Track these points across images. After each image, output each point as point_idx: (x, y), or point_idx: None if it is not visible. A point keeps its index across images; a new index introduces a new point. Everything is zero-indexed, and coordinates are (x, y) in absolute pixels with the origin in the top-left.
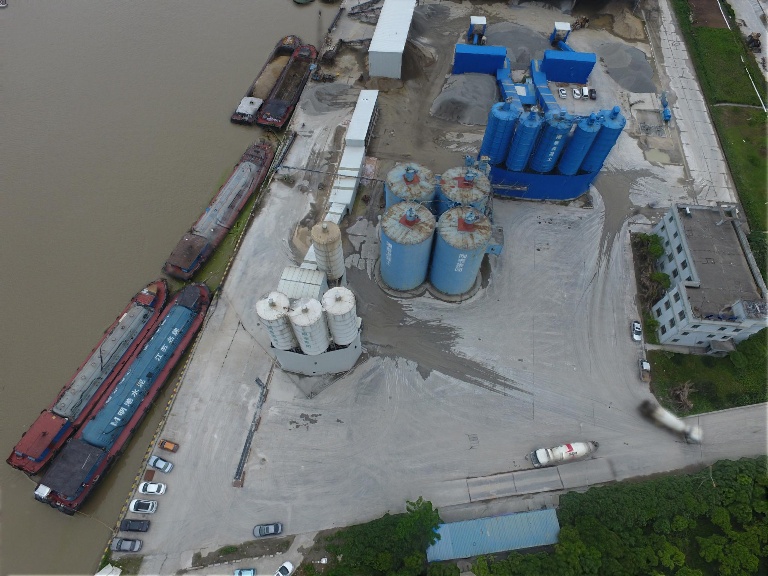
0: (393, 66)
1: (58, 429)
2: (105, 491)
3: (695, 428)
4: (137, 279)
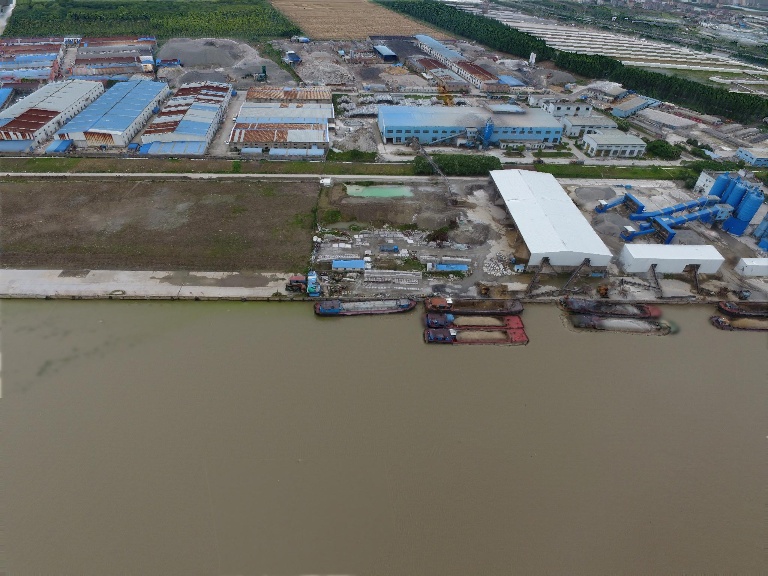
0: None
1: None
2: None
3: None
4: None
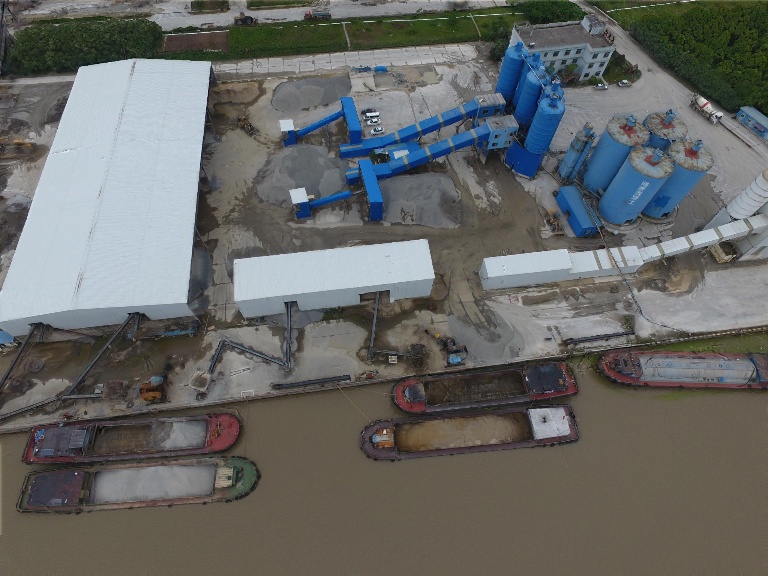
0: None
1: None
2: None
3: (641, 68)
4: None
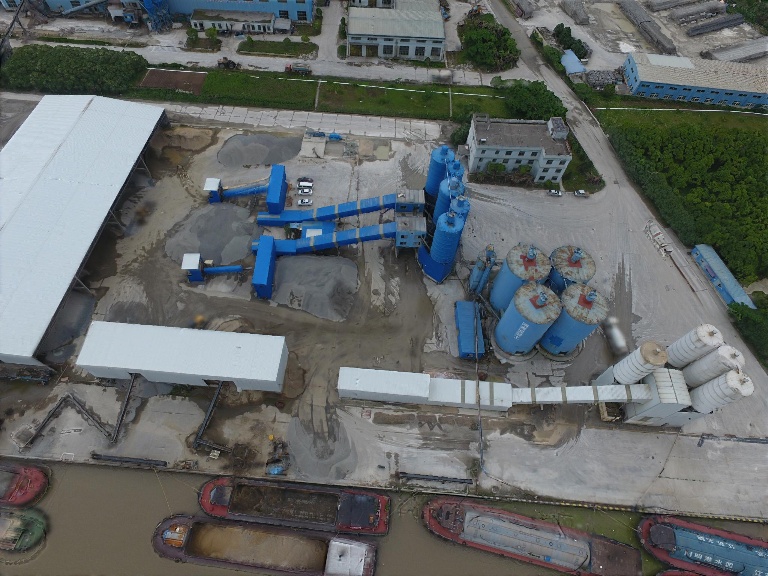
0: (284, 356)
1: None
2: None
3: (608, 179)
4: None
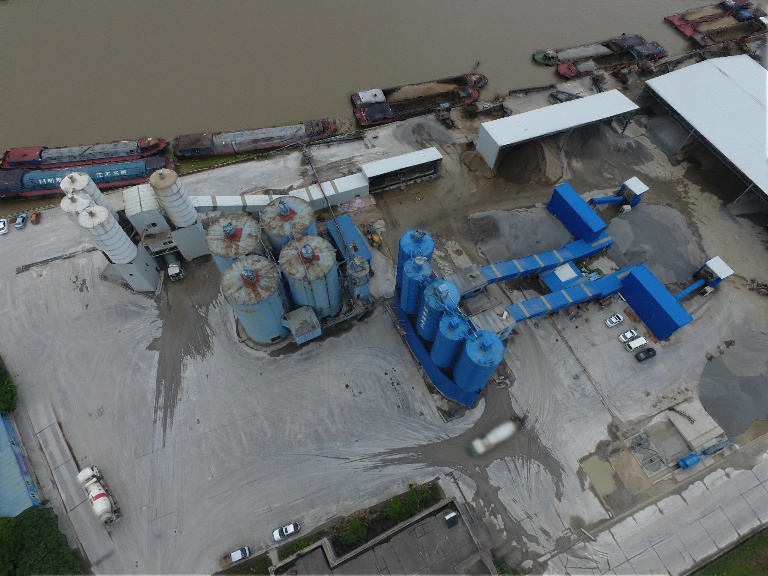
0: (491, 153)
1: (30, 159)
2: (4, 208)
3: None
4: (168, 133)
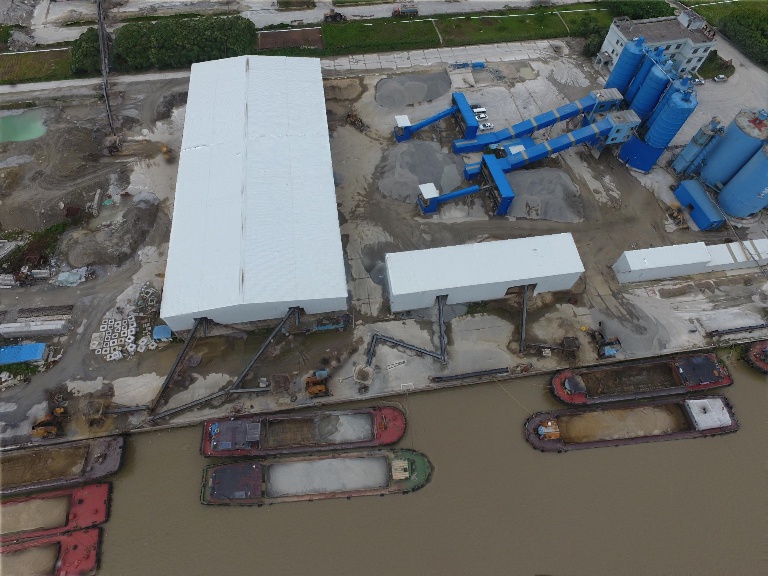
0: None
1: None
2: None
3: (734, 63)
4: None
